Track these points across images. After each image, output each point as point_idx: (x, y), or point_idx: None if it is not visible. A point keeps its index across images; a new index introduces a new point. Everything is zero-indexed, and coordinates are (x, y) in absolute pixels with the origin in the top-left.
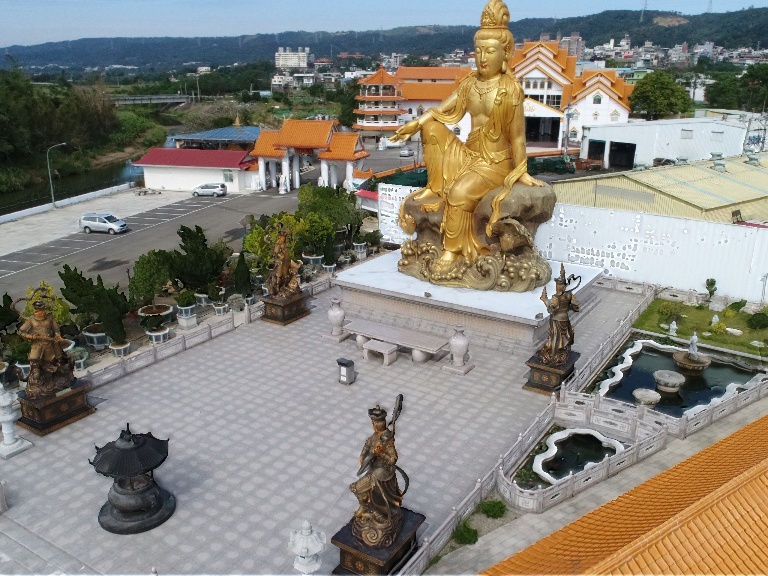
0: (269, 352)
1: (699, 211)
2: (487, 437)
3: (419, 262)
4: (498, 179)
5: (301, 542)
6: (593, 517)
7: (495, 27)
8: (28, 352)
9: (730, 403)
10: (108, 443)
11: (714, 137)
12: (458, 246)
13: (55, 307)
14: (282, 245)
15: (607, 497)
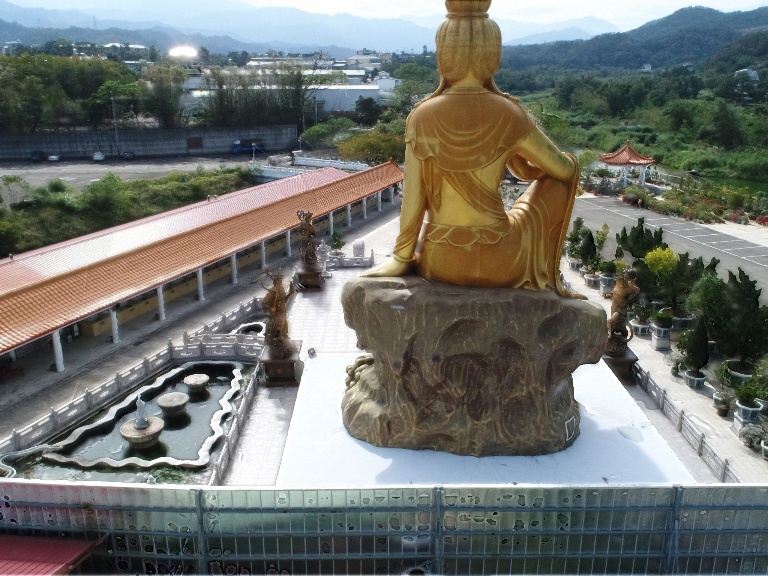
0: None
1: None
2: None
3: None
4: None
5: None
6: (223, 253)
7: None
8: None
9: (125, 375)
10: None
11: None
12: None
13: None
14: None
15: None
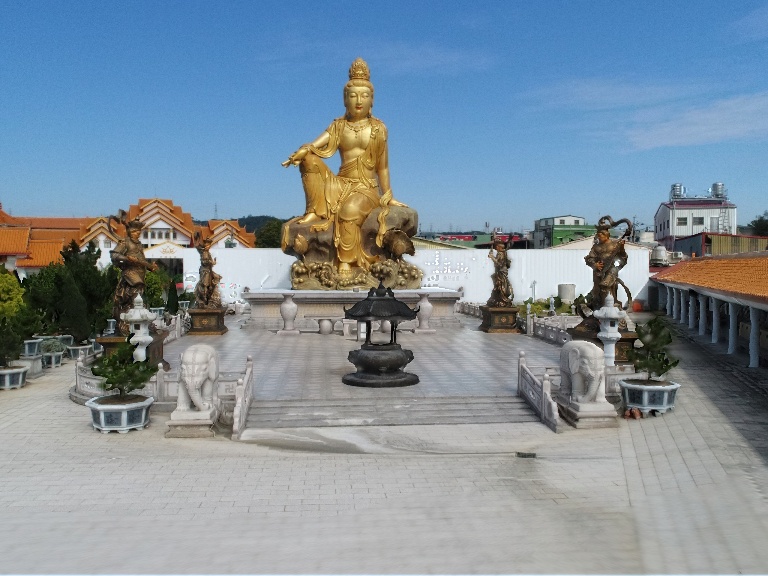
0: (250, 341)
1: None
2: None
3: (314, 279)
4: (376, 201)
5: (614, 310)
6: (723, 286)
7: (366, 78)
8: (34, 323)
9: None
10: (360, 303)
11: None
12: (354, 257)
13: (15, 290)
14: None
15: None
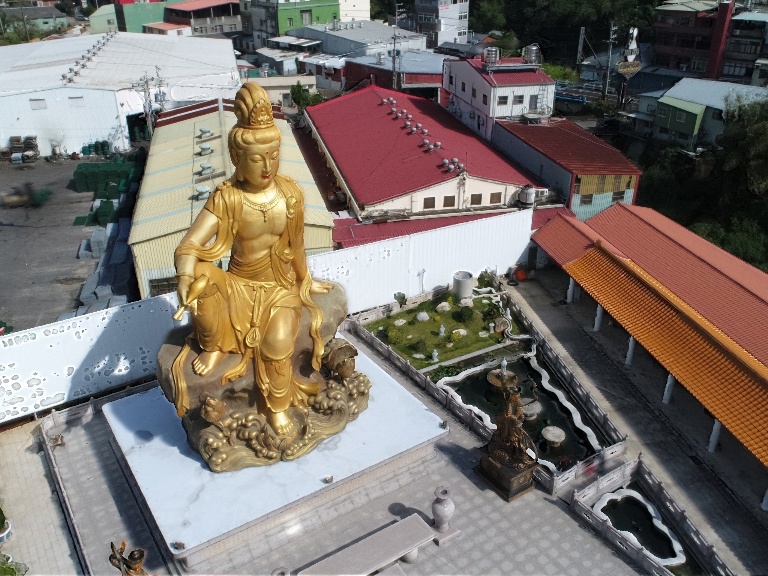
0: None
1: (326, 230)
2: (600, 572)
3: (238, 445)
4: (299, 302)
5: None
6: None
7: (272, 124)
8: None
9: None
10: None
11: (74, 103)
12: (290, 400)
13: None
14: (144, 573)
15: (710, 539)
